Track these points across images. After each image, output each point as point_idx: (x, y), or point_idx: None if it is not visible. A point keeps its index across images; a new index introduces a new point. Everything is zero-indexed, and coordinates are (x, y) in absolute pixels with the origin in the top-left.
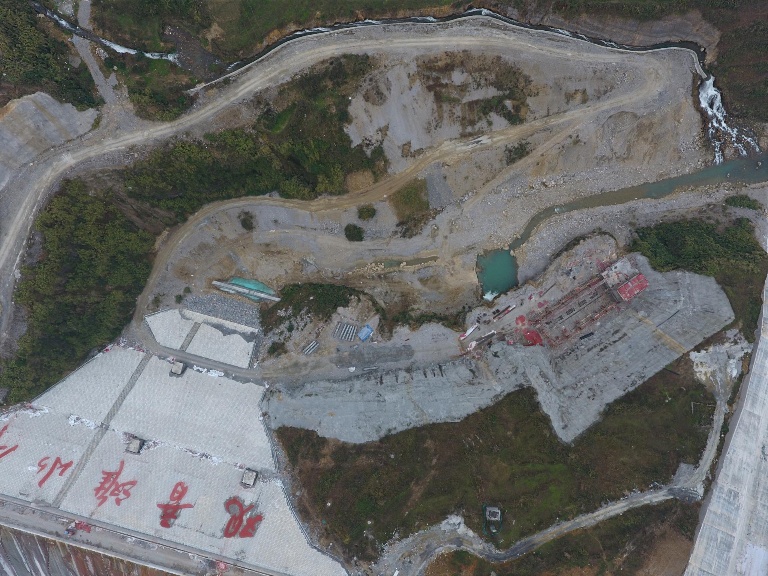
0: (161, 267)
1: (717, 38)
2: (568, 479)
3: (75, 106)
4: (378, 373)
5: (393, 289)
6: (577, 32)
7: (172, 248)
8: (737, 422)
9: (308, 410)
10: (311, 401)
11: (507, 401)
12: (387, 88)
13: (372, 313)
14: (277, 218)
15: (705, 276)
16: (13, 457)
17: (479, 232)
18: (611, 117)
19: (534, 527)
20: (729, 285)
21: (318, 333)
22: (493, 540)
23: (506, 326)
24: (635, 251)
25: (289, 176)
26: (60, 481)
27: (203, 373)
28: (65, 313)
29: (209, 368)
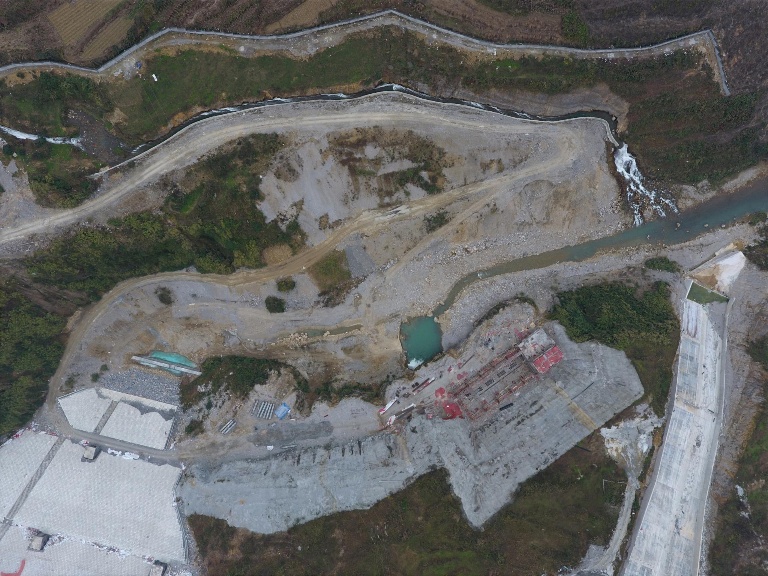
0: (74, 347)
1: (626, 109)
2: (477, 567)
3: None
4: (296, 451)
5: (316, 359)
6: (489, 104)
7: (86, 327)
8: (649, 497)
9: (220, 497)
10: (223, 487)
11: (418, 484)
12: (299, 165)
13: (291, 388)
14: (195, 292)
15: (616, 350)
16: None
17: (402, 300)
18: (528, 185)
19: None
20: (639, 358)
21: (235, 411)
22: None
23: (426, 399)
24: (554, 319)
25: (203, 253)
26: None
27: (117, 456)
28: None
29: (124, 451)
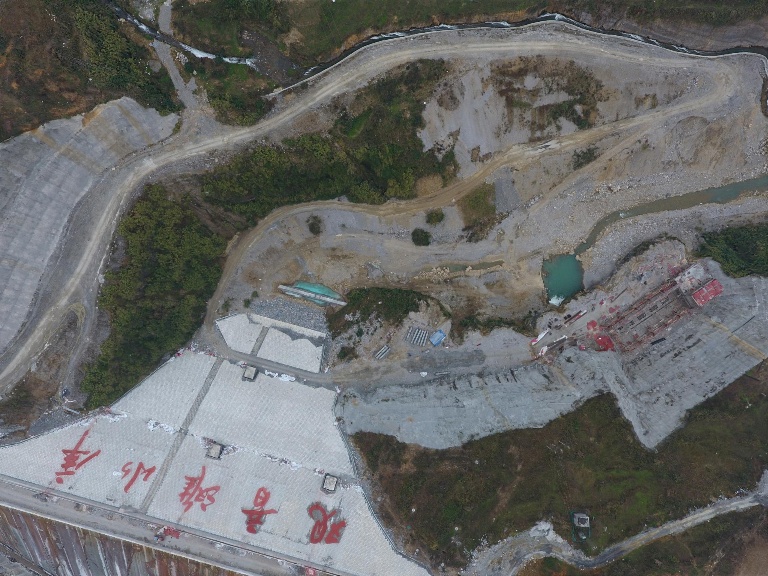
0: (231, 271)
1: None
2: (654, 485)
3: (158, 111)
4: (450, 378)
5: (459, 293)
6: (649, 37)
7: (242, 252)
8: None
9: (386, 415)
10: (388, 406)
11: (588, 407)
12: (461, 93)
13: (442, 318)
14: (345, 222)
15: None
16: (97, 462)
17: (545, 237)
18: (680, 122)
19: (622, 534)
20: None
21: (389, 338)
22: (582, 547)
23: (577, 331)
24: (705, 256)
25: (360, 181)
26: (145, 486)
27: (275, 378)
28: (145, 318)
29: (280, 373)
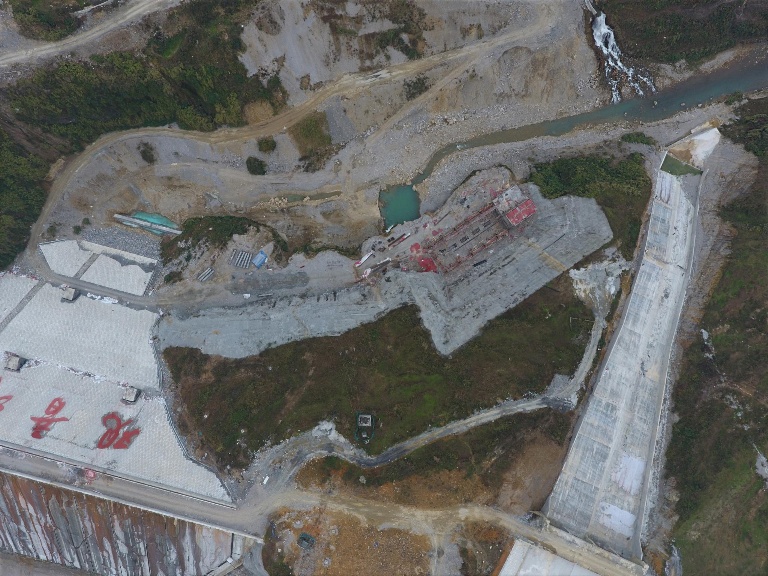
0: (57, 196)
1: None
2: (443, 389)
3: None
4: (272, 299)
5: (296, 223)
6: None
7: (68, 177)
8: (616, 338)
9: (195, 330)
10: (198, 322)
11: (389, 317)
12: (280, 17)
13: None
14: (178, 150)
15: (587, 198)
16: None
17: (381, 167)
18: (507, 53)
19: (407, 434)
20: (610, 206)
21: (213, 260)
22: (365, 446)
23: (401, 254)
24: (529, 182)
25: (185, 105)
26: None
27: (96, 300)
28: None
29: (103, 295)
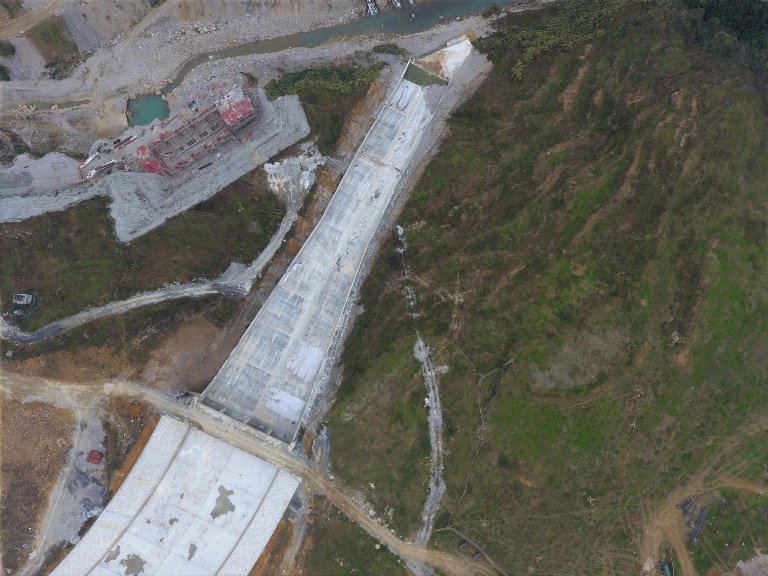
0: None
1: None
2: (111, 272)
3: None
4: None
5: (41, 130)
6: None
7: None
8: (311, 233)
9: None
10: None
11: (77, 207)
12: None
13: None
14: None
15: (292, 95)
16: None
17: (129, 75)
18: None
19: (66, 314)
20: (313, 103)
21: None
22: (20, 323)
23: (127, 156)
24: None
25: None
26: None
27: None
28: None
29: None
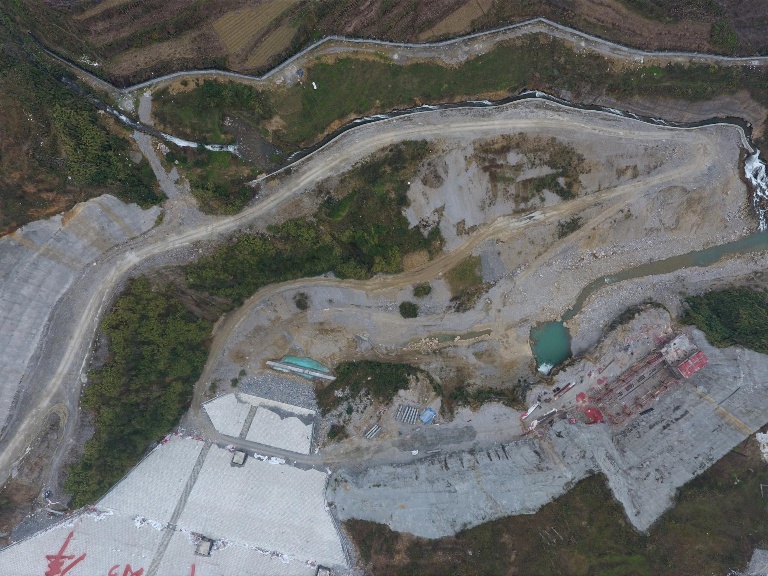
0: (218, 352)
1: (764, 115)
2: (647, 571)
3: (140, 205)
4: (442, 456)
5: (448, 364)
6: (628, 111)
7: (228, 333)
8: None
9: (377, 502)
10: (380, 492)
11: (579, 489)
12: (444, 171)
13: (432, 393)
14: (332, 298)
15: (766, 355)
16: (82, 567)
17: (532, 305)
18: (661, 191)
19: None
20: None
21: (379, 416)
22: None
23: (567, 404)
24: (690, 324)
25: (346, 259)
26: None
27: (264, 461)
28: (129, 412)
29: (270, 455)
